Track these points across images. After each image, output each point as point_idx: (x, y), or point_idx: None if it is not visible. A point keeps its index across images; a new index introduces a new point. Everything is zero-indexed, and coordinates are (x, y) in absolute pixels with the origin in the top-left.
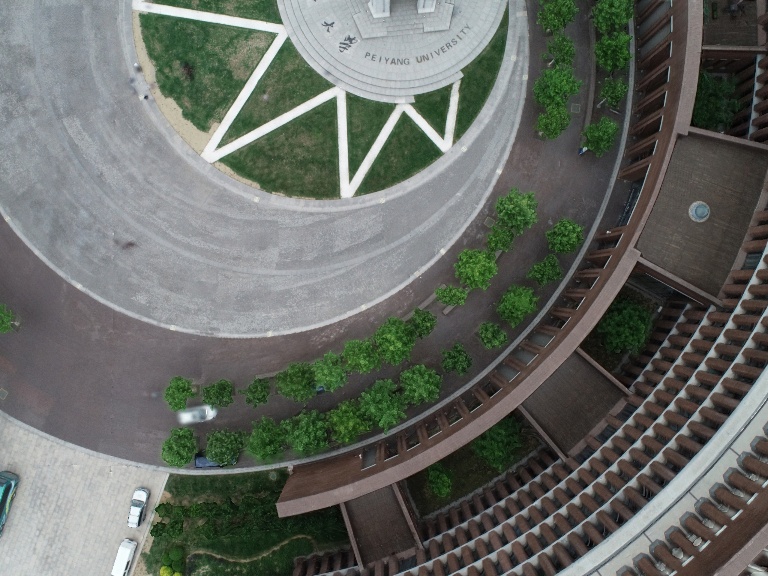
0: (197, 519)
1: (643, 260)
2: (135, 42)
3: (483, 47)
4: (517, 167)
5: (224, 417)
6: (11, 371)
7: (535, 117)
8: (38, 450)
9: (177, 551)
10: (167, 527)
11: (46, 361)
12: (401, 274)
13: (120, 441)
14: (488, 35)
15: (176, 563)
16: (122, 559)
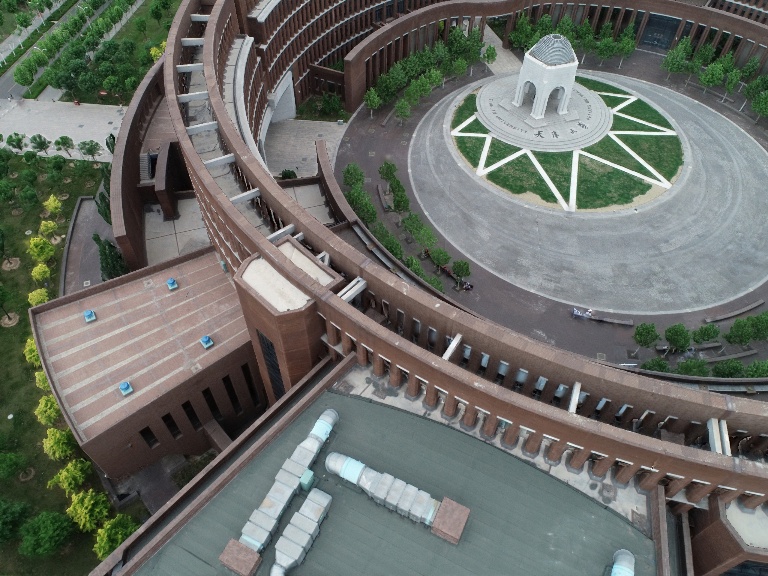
0: None
1: (706, 5)
2: (598, 212)
3: (576, 83)
4: (640, 76)
5: None
6: None
7: (611, 69)
8: None
9: None
10: None
11: None
12: (716, 116)
13: None
14: None
15: None
16: None
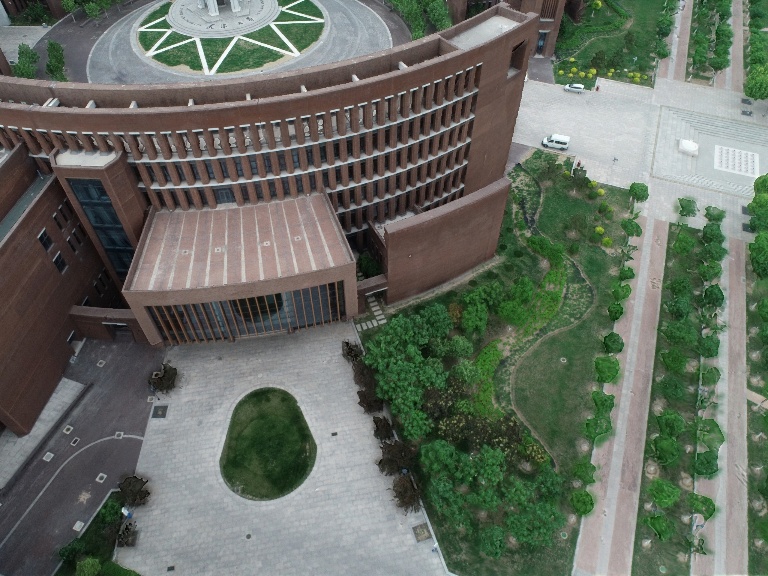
0: None
1: None
2: (231, 74)
3: None
4: None
5: None
6: None
7: None
8: None
9: None
10: None
11: None
12: None
13: None
14: None
15: None
16: None
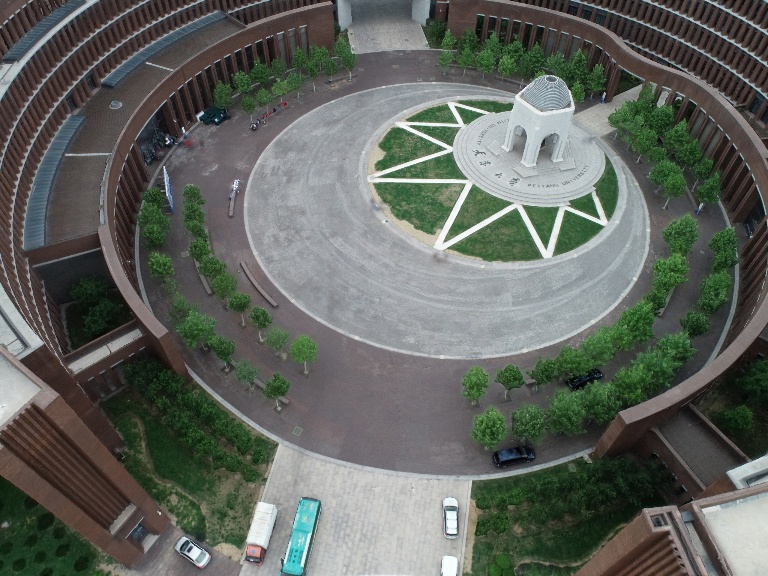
0: (512, 524)
1: None
2: (373, 196)
3: (601, 174)
4: (659, 226)
5: (508, 421)
6: (304, 410)
7: (655, 201)
8: (336, 478)
9: (505, 555)
10: (492, 520)
11: (335, 398)
12: (611, 297)
13: (416, 457)
14: (601, 169)
15: (507, 571)
16: (451, 570)
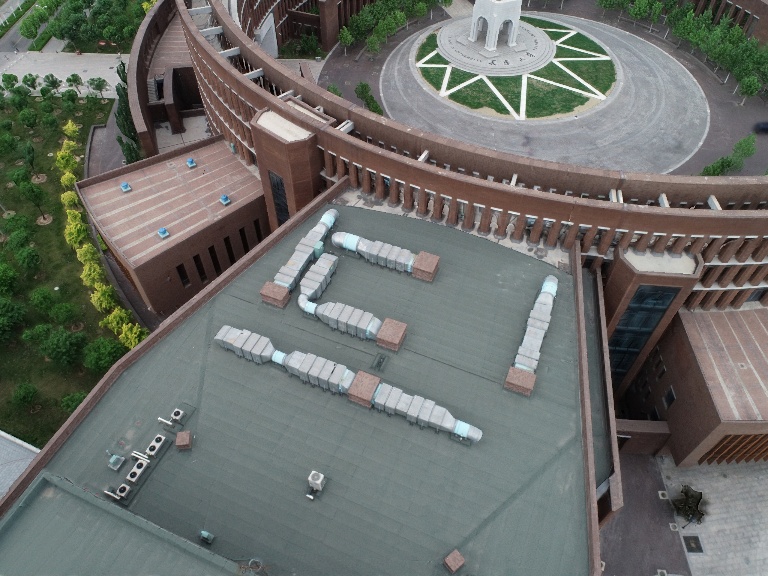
0: None
1: None
2: None
3: None
4: None
5: None
6: None
7: (554, 10)
8: None
9: None
10: None
11: (755, 157)
12: None
13: None
14: None
15: None
16: None
